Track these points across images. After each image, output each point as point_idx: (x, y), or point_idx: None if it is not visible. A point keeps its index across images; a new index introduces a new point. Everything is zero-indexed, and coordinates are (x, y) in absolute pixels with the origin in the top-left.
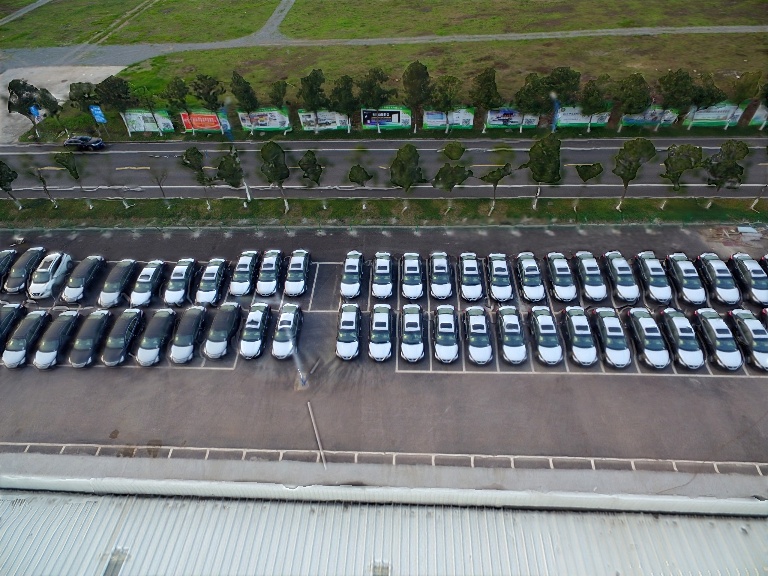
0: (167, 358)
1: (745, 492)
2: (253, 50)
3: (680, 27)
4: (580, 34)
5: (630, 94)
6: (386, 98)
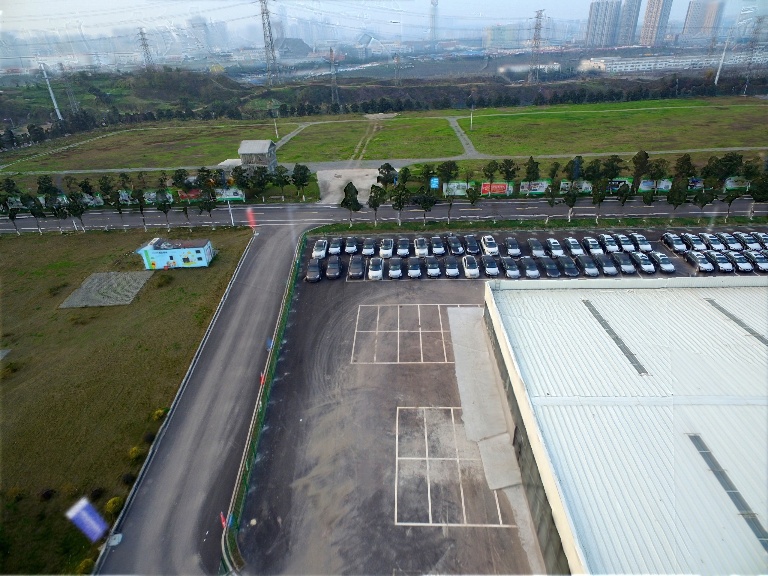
0: (603, 273)
1: None
2: None
3: (759, 147)
4: (695, 151)
5: None
6: (618, 173)
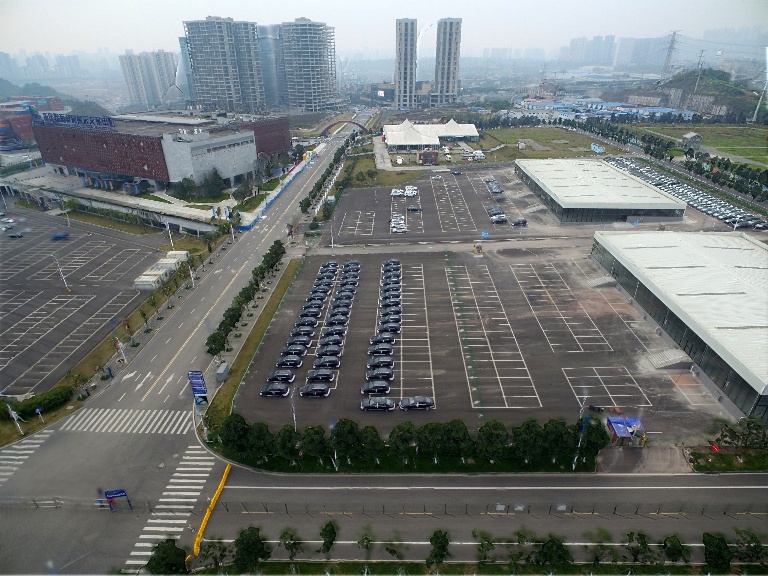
0: None
1: None
2: None
3: None
4: None
5: None
6: None
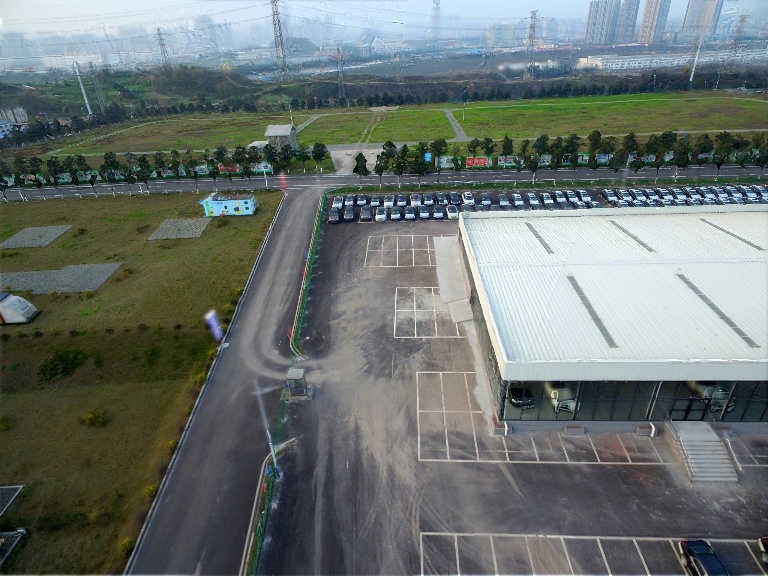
0: None
1: None
2: (466, 142)
3: (706, 130)
4: None
5: (703, 142)
6: (577, 148)
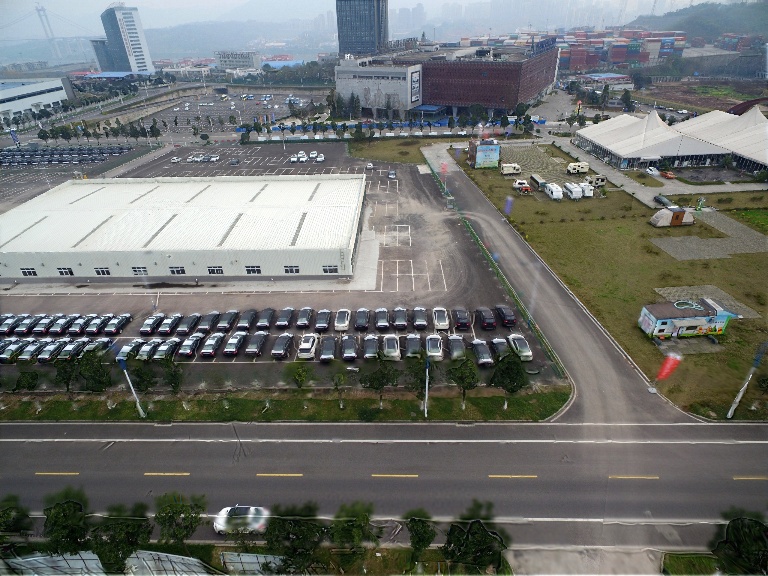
0: None
1: (8, 291)
2: None
3: None
4: None
5: None
6: None
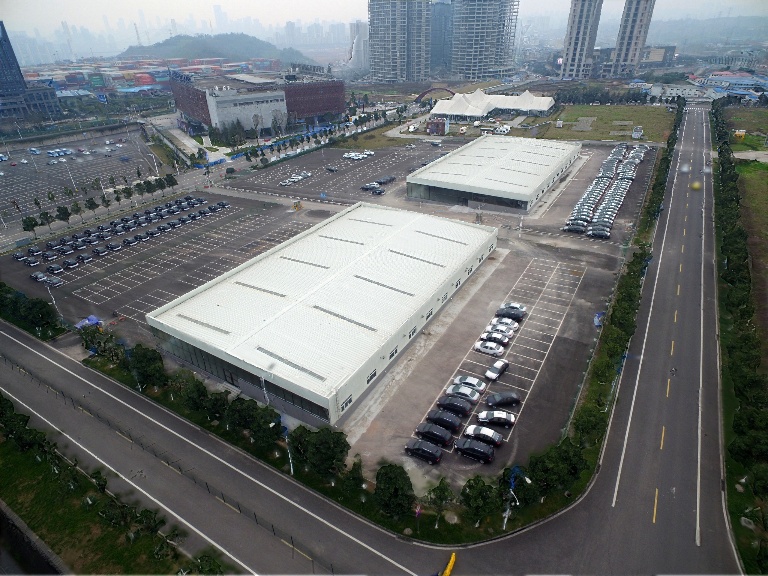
0: None
1: None
2: None
3: None
4: None
5: None
6: None
